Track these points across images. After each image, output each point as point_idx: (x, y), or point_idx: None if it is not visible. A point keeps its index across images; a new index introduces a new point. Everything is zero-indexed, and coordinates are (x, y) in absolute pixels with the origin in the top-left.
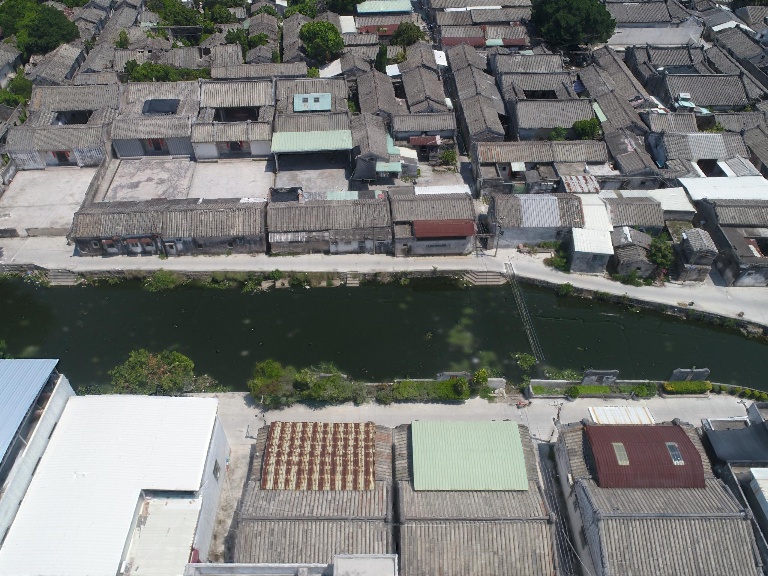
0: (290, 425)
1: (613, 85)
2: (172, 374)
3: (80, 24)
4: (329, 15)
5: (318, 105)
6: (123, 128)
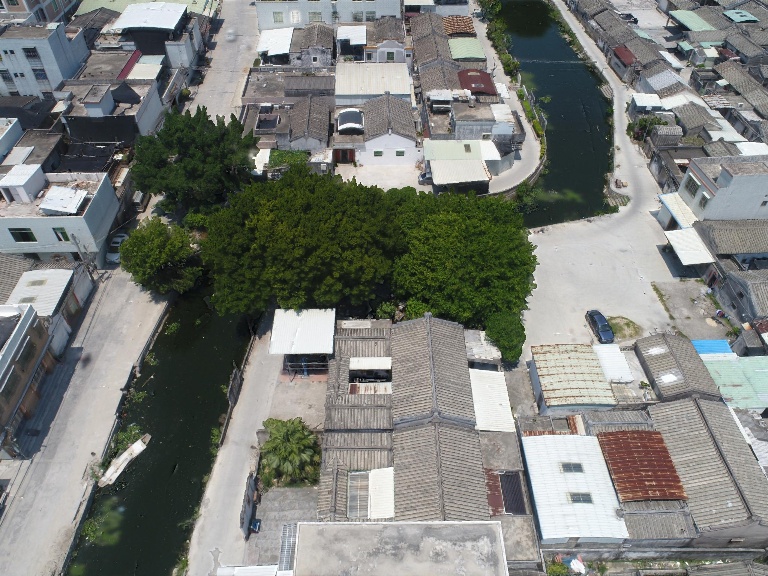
0: None
1: None
2: (488, 1)
3: None
4: None
5: (737, 17)
6: None
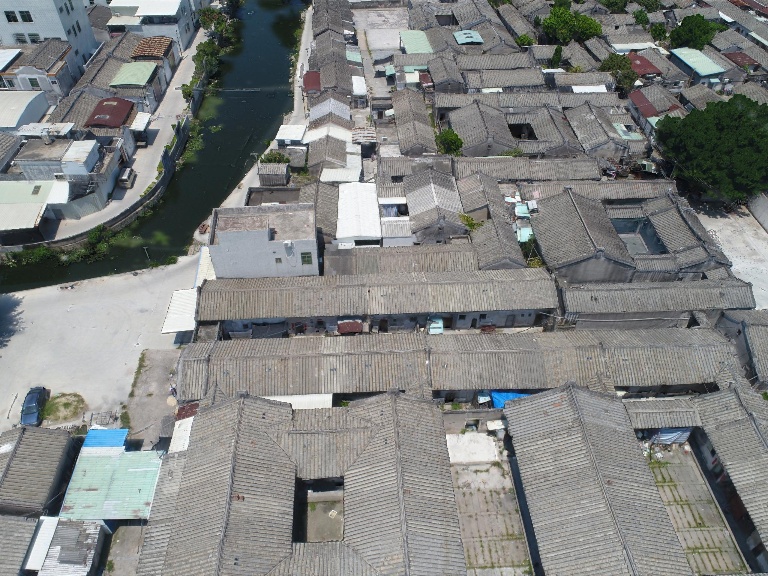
0: (169, 41)
1: (560, 172)
2: None
3: None
4: (642, 35)
5: (462, 38)
6: None
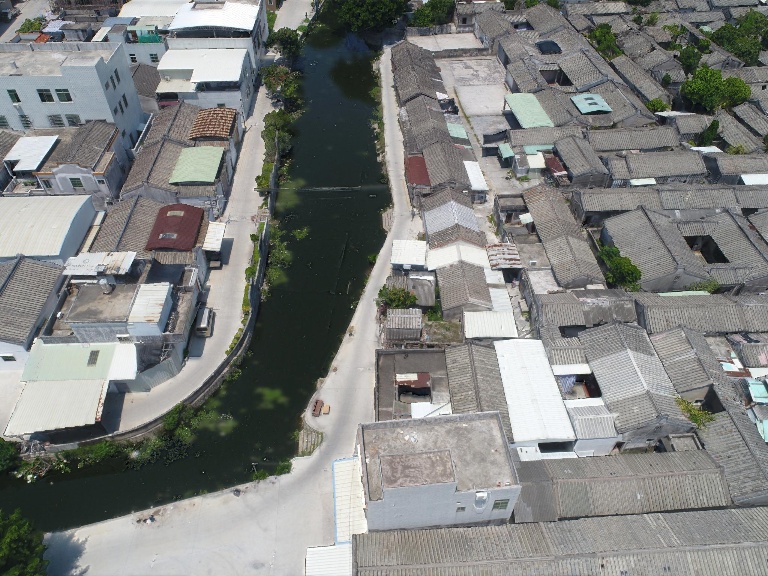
0: (233, 114)
1: None
2: None
3: (667, 2)
4: None
5: (584, 106)
6: (509, 40)
